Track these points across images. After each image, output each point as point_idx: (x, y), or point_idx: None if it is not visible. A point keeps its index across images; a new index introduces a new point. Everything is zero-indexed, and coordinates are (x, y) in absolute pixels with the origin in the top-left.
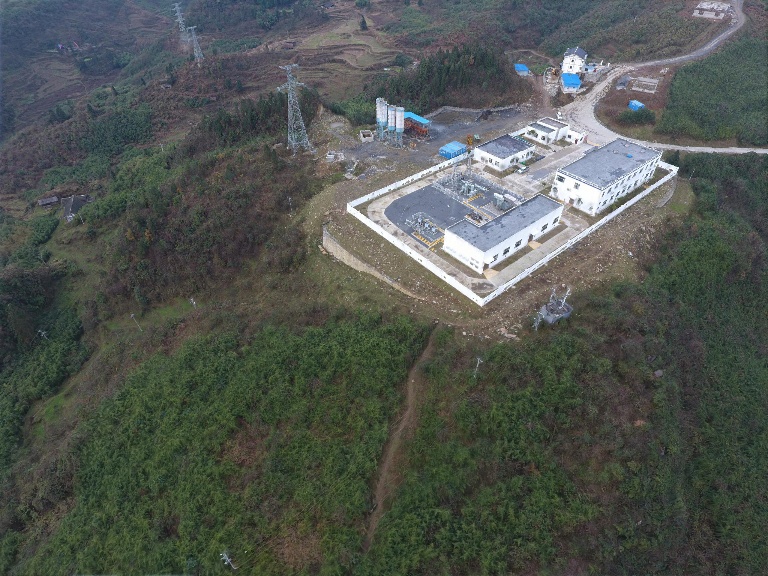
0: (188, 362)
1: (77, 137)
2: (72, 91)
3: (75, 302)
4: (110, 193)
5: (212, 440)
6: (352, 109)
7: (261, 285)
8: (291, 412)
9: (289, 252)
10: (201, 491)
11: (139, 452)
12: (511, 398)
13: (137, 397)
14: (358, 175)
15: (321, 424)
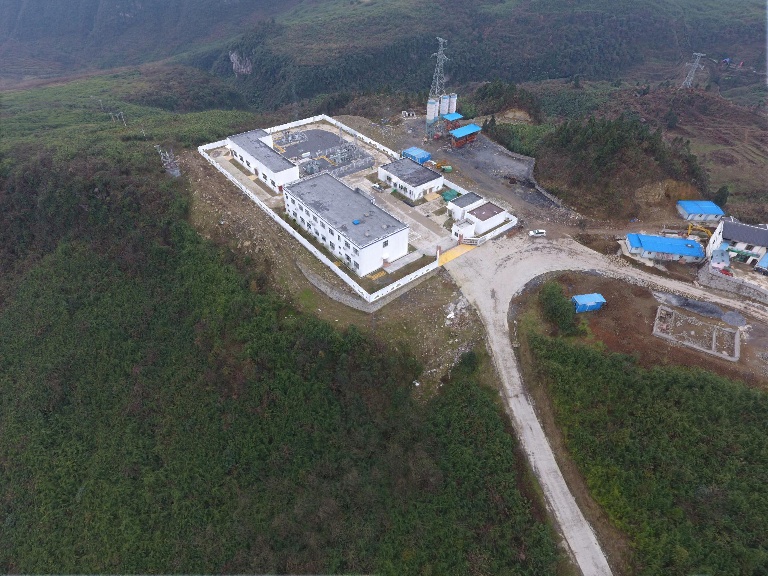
0: None
1: (548, 94)
2: None
3: None
4: None
5: None
6: None
7: None
8: None
9: None
10: None
11: None
12: None
13: None
14: None
15: None
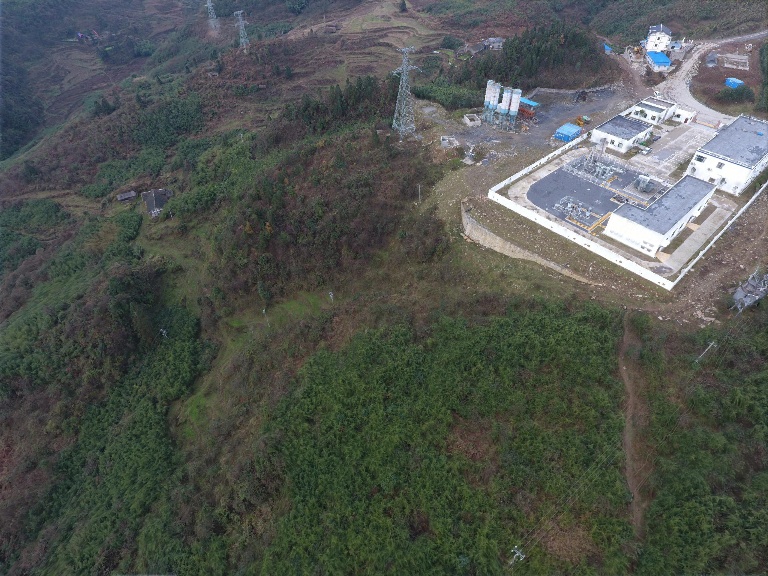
0: (371, 357)
1: (129, 129)
2: (97, 82)
3: (182, 299)
4: (193, 186)
5: (433, 435)
6: (441, 93)
7: (403, 276)
8: (509, 404)
9: (432, 241)
10: (446, 487)
11: (353, 450)
12: (750, 382)
13: (327, 394)
14: (478, 160)
15: (544, 415)
